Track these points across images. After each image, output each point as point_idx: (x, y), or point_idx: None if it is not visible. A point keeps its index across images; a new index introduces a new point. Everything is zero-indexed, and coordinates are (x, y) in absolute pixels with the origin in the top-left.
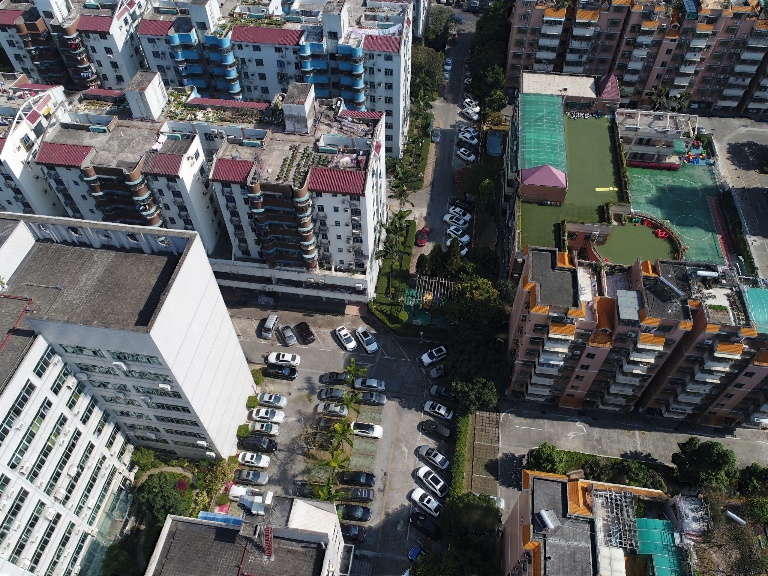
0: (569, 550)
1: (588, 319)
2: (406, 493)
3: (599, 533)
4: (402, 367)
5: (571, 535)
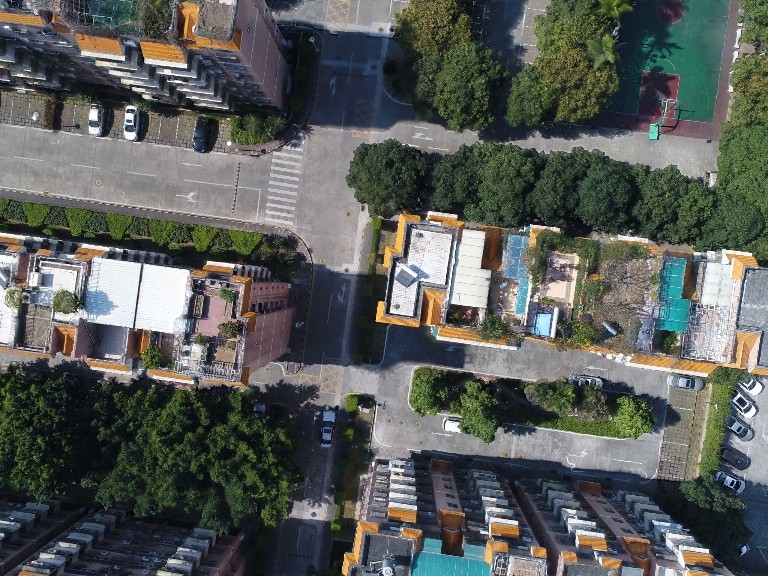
0: (764, 301)
1: (661, 574)
2: (765, 391)
3: (725, 318)
4: (767, 537)
5: (759, 314)
